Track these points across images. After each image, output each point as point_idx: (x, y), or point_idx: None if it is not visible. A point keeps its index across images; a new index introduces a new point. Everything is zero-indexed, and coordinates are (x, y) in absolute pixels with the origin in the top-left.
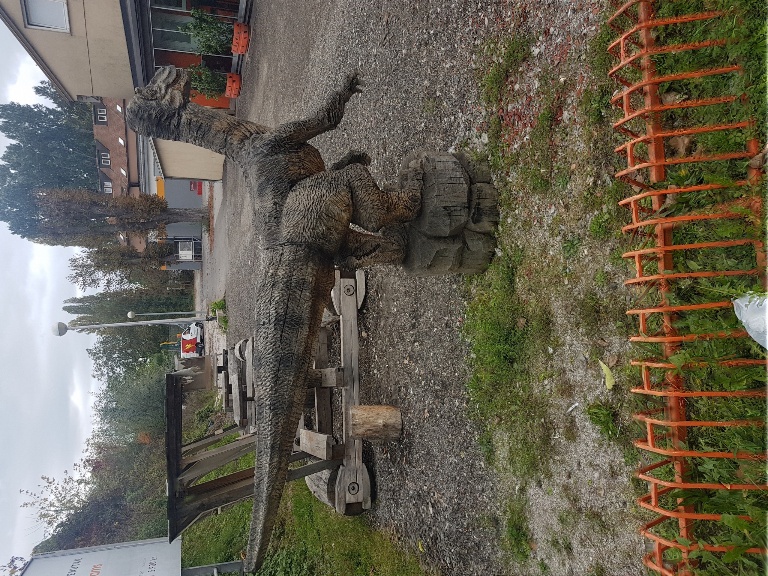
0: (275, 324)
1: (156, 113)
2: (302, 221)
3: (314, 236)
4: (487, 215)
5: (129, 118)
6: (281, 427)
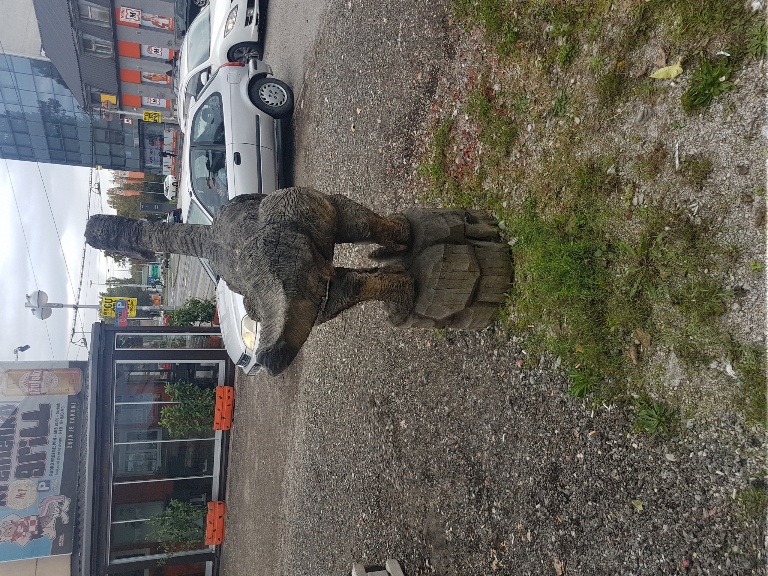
0: (265, 244)
1: None
2: (282, 202)
3: (298, 215)
4: (482, 220)
5: (89, 228)
6: (295, 279)
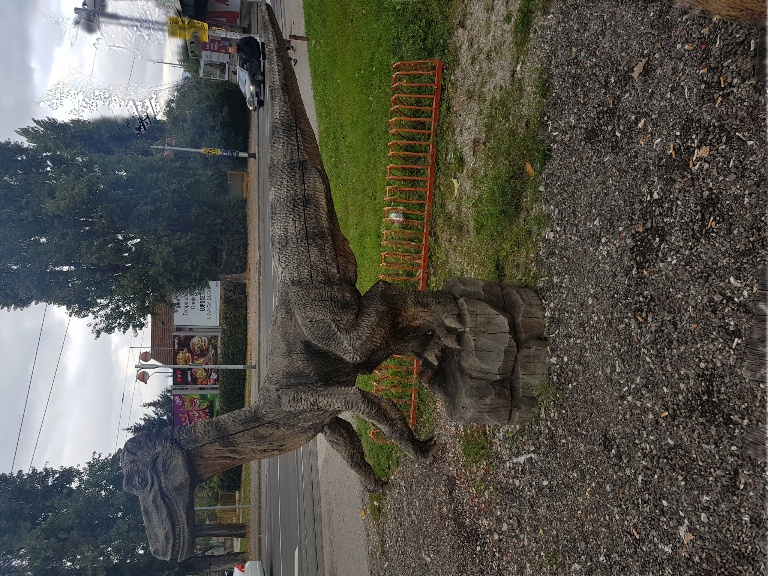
0: None
1: None
2: None
3: None
4: None
5: None
6: None
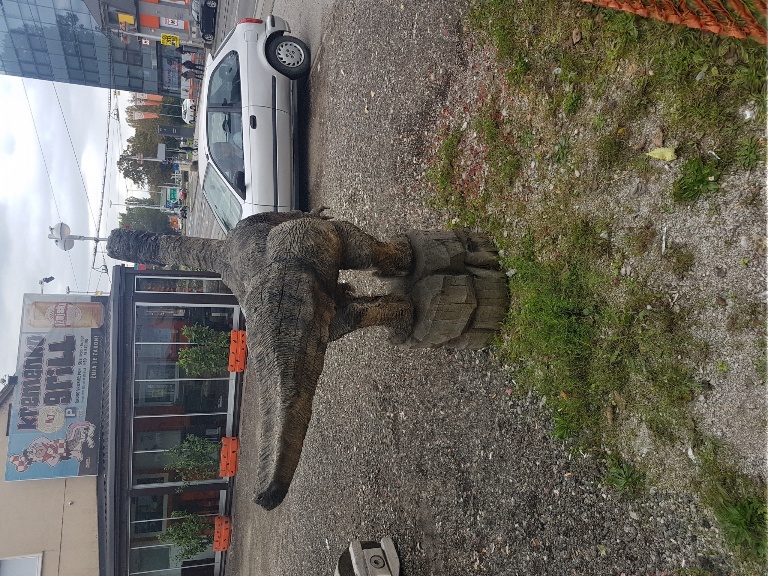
0: (269, 300)
1: (134, 232)
2: (288, 237)
3: (303, 252)
4: (483, 247)
5: (106, 243)
6: (293, 364)
